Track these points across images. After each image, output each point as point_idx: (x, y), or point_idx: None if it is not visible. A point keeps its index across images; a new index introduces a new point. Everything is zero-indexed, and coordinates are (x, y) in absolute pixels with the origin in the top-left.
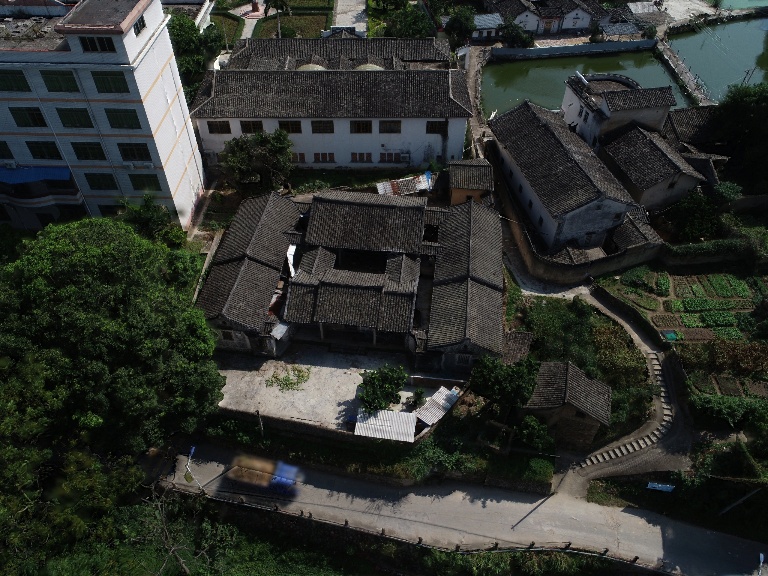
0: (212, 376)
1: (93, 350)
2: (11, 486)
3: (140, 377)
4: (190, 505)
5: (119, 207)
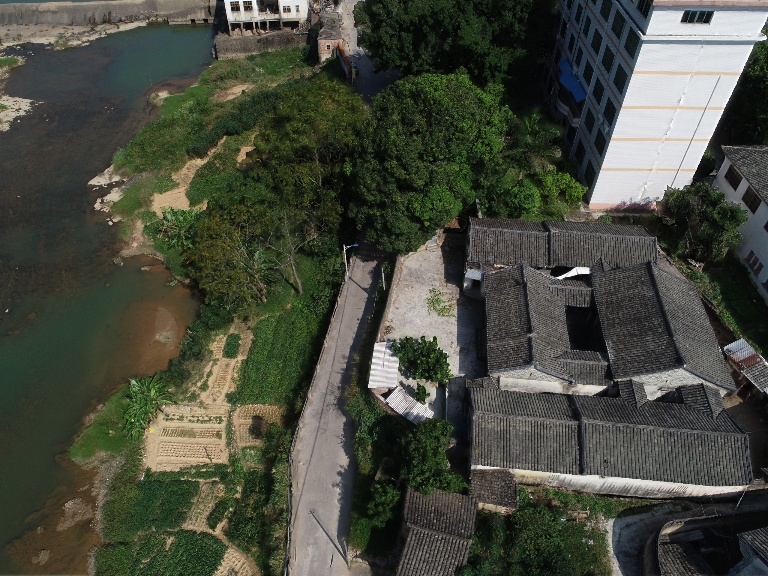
0: (396, 222)
1: (376, 135)
2: (294, 143)
3: (378, 177)
4: (338, 275)
5: (584, 150)
